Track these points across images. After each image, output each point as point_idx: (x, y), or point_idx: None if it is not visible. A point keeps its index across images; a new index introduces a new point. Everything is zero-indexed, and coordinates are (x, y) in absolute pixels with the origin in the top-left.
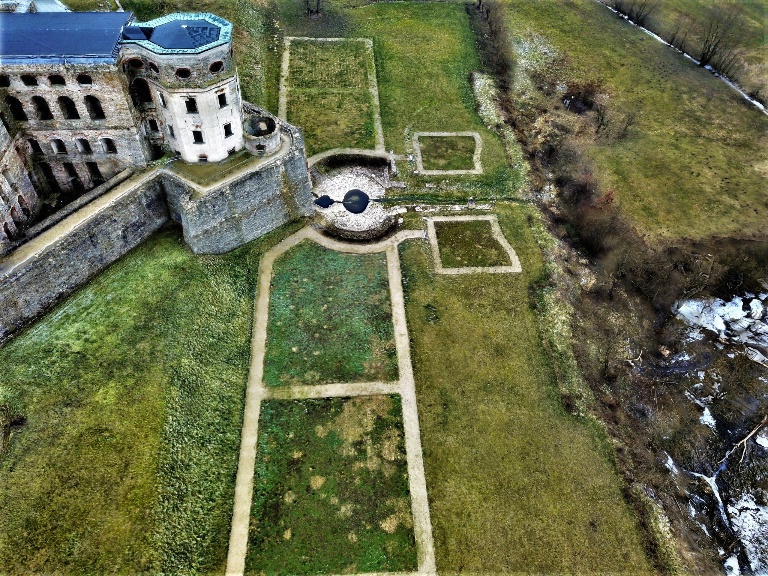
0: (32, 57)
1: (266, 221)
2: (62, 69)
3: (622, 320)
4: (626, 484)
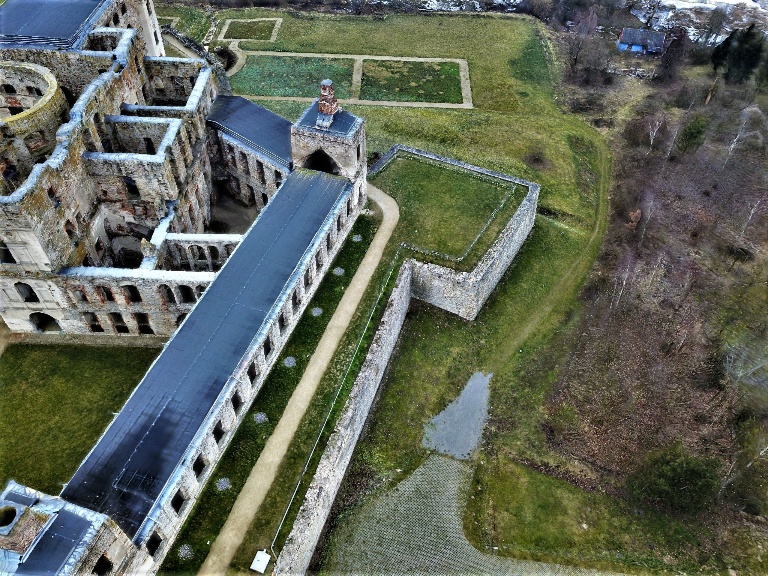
0: (100, 5)
1: None
2: (115, 5)
3: (321, 8)
4: None
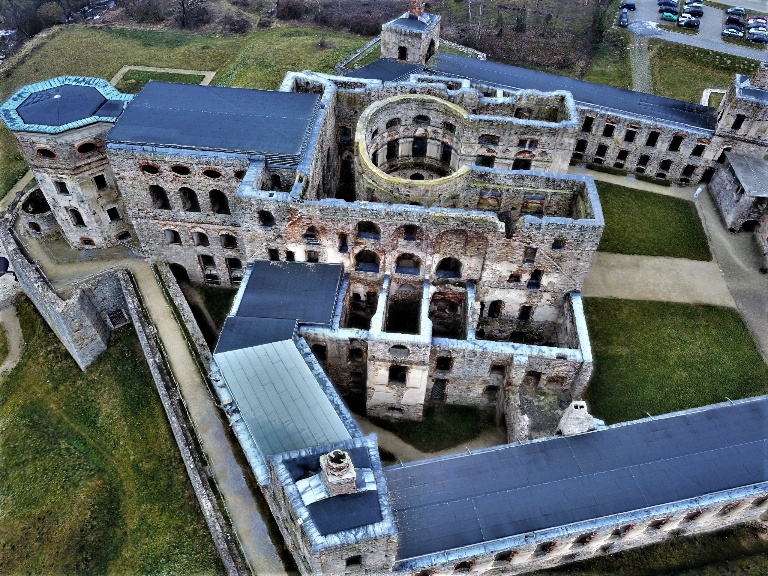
0: None
1: None
2: None
3: None
4: (3, 78)
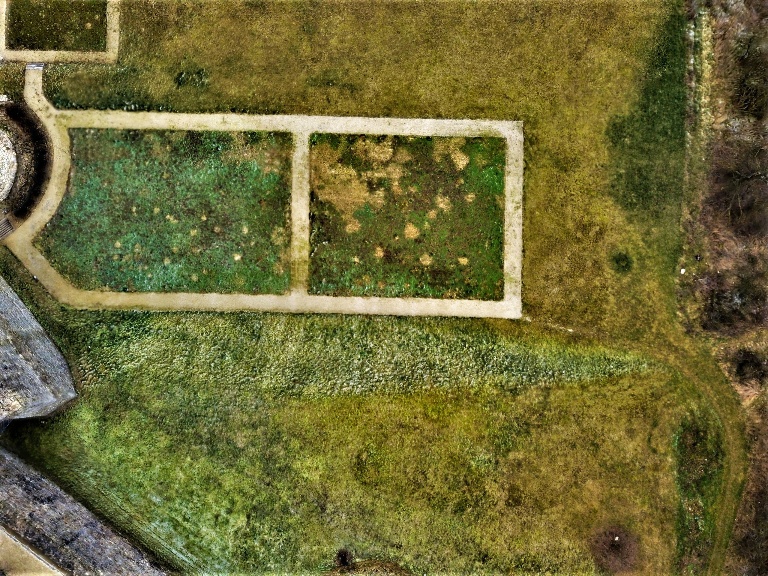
0: None
1: (4, 299)
2: None
3: None
4: None
